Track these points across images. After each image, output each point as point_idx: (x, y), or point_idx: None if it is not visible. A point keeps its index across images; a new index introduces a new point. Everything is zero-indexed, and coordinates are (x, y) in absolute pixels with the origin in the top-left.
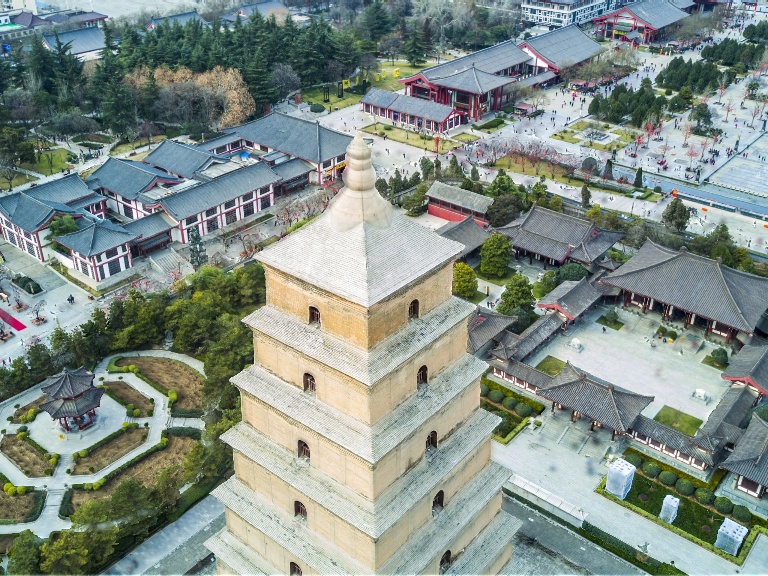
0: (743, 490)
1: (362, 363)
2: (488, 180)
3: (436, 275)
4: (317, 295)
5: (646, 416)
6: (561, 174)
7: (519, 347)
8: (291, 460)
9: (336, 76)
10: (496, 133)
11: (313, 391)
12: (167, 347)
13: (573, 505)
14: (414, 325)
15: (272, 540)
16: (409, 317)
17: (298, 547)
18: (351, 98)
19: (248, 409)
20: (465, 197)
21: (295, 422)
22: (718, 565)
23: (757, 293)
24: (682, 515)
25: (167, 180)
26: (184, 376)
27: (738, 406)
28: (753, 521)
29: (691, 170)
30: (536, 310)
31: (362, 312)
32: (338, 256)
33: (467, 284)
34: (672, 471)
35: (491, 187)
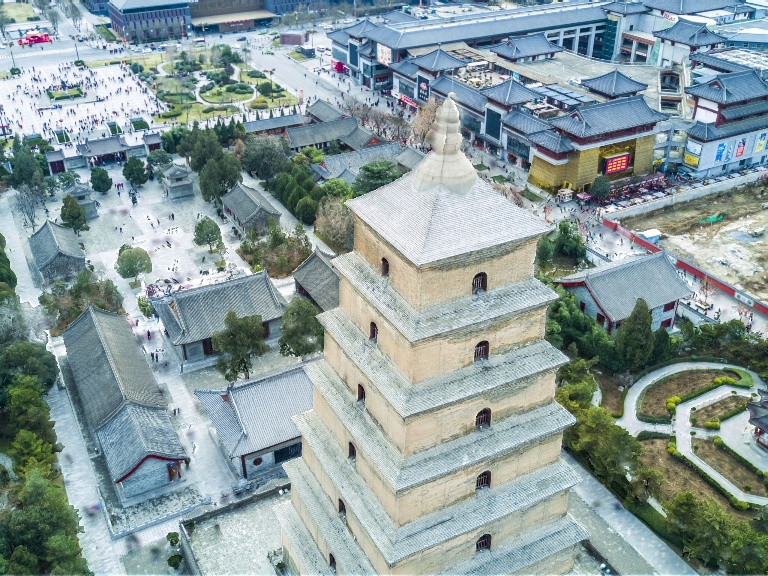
0: None
1: None
2: None
3: None
4: None
5: None
6: None
7: None
8: None
9: None
10: None
11: None
12: None
13: None
14: (381, 280)
15: None
16: None
17: None
18: None
19: None
20: None
21: None
22: None
23: None
24: None
25: None
26: None
27: None
28: None
29: None
30: None
31: None
32: None
33: None
34: None
35: None
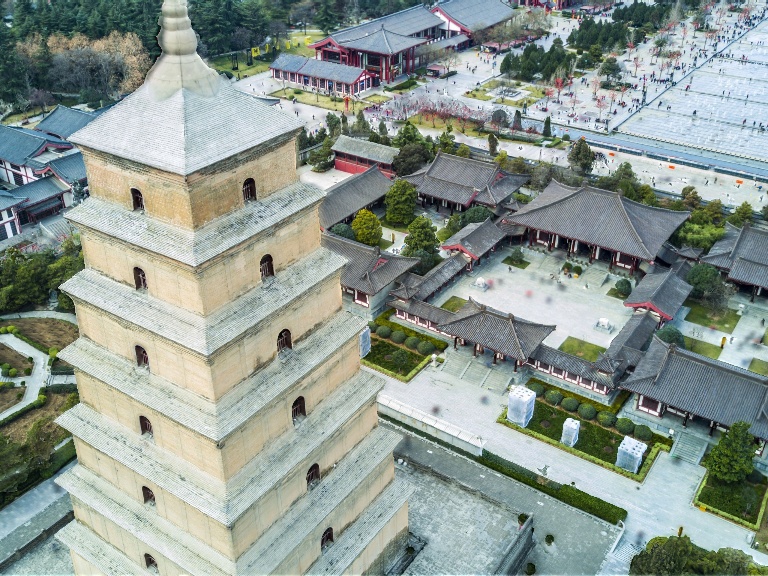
0: (644, 410)
1: (187, 244)
2: (396, 134)
3: (274, 153)
4: (136, 173)
5: (549, 346)
6: (472, 128)
7: (421, 287)
8: (130, 370)
9: (244, 43)
10: (408, 94)
11: (146, 289)
12: (51, 307)
13: (472, 434)
14: (251, 207)
15: (122, 465)
16: (246, 200)
17: (145, 466)
18: (261, 66)
19: (83, 320)
20: (371, 149)
21: (129, 324)
22: (619, 483)
23: (659, 224)
24: (584, 438)
25: (58, 144)
26: (68, 334)
27: (640, 331)
28: (654, 439)
29: (600, 121)
30: (442, 254)
31: (181, 184)
32: (155, 127)
33: (370, 231)
34: (575, 397)
35: (397, 138)
